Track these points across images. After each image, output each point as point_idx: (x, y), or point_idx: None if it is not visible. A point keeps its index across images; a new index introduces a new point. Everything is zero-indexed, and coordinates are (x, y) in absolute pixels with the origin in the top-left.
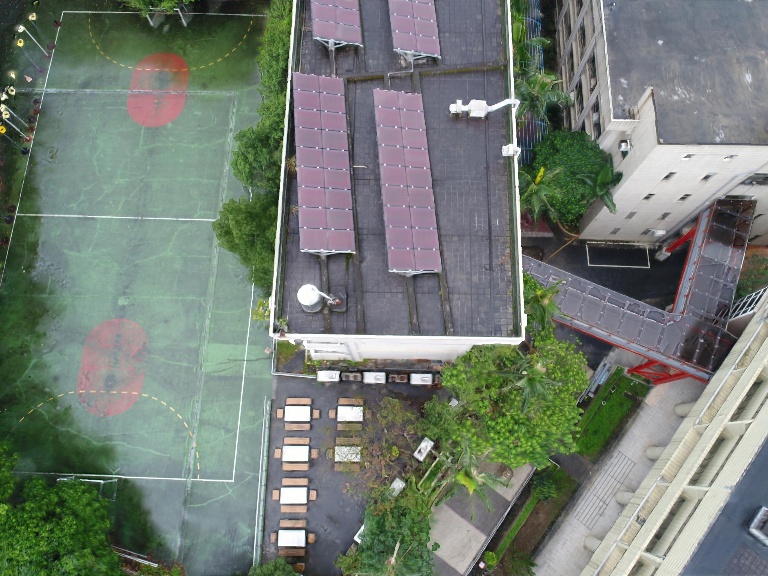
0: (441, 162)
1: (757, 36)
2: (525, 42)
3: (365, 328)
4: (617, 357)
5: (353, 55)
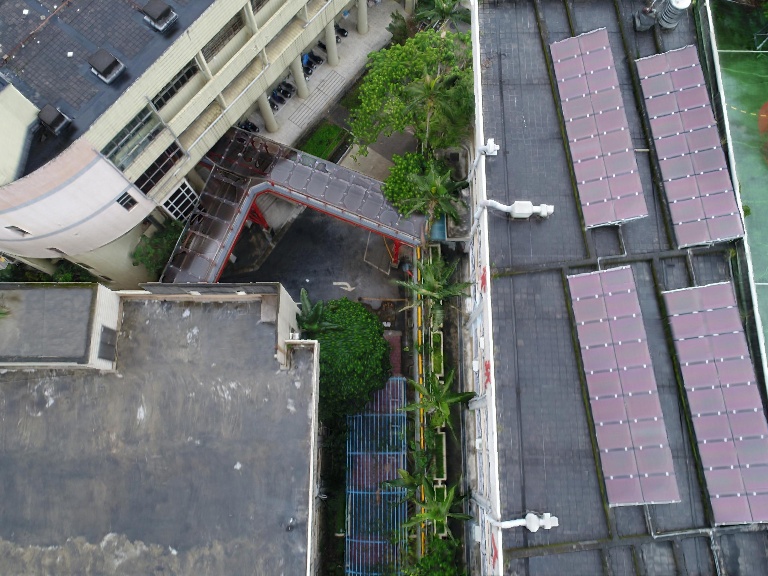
0: (555, 158)
1: (115, 476)
2: (370, 574)
3: (614, 2)
4: (290, 213)
5: (670, 287)
